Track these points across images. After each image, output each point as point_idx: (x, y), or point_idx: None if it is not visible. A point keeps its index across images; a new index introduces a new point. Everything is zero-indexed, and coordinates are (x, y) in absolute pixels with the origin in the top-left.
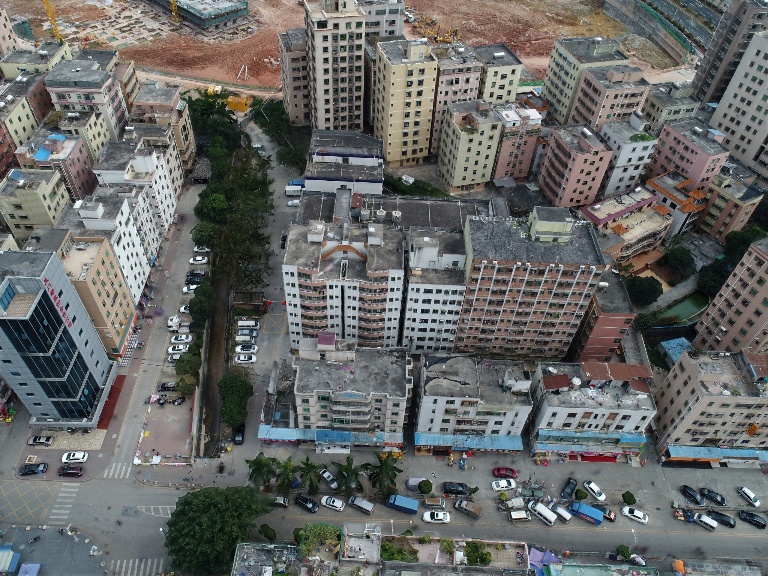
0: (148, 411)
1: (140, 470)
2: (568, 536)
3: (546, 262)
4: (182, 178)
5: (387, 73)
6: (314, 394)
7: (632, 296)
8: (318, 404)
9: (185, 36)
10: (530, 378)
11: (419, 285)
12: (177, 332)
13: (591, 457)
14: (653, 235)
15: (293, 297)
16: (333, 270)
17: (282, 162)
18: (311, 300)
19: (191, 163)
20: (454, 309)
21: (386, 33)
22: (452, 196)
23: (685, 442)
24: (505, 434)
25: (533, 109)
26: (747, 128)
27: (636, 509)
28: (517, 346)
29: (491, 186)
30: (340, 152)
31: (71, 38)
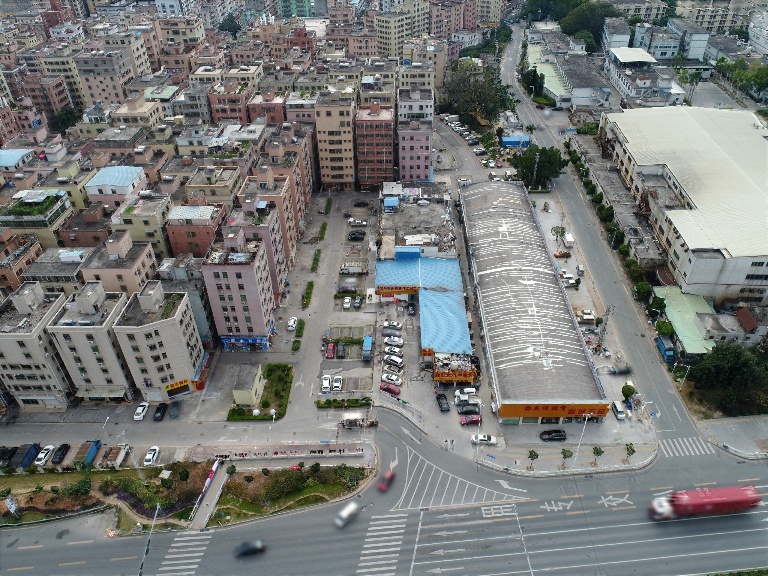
0: None
1: None
2: None
3: None
4: None
5: None
6: None
7: None
8: None
9: None
10: None
11: None
12: None
13: None
14: None
15: None
16: None
17: None
18: None
19: None
20: None
21: None
22: None
23: (240, 8)
24: None
25: None
26: None
27: None
28: None
29: None
30: (118, 0)
31: None
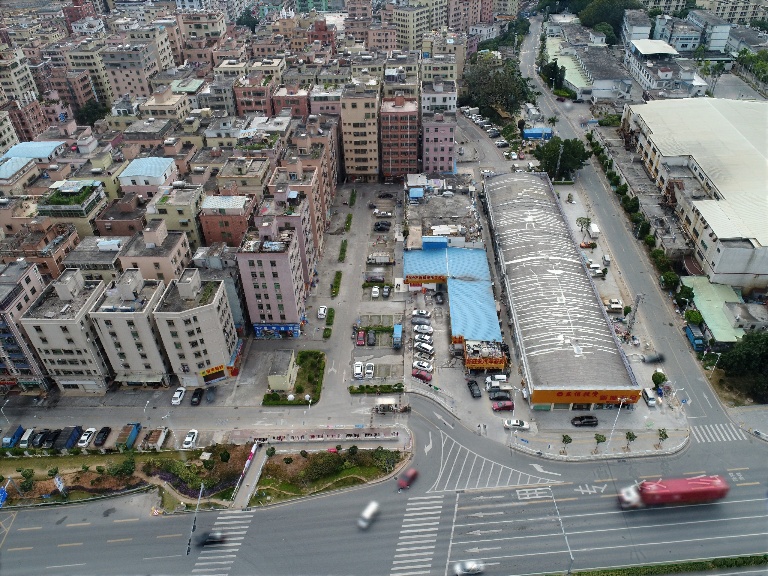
0: None
1: None
2: None
3: None
4: None
5: None
6: (226, 6)
7: None
8: None
9: None
10: None
11: None
12: None
13: None
14: None
15: None
16: None
17: None
18: None
19: None
20: None
21: None
22: None
23: (256, 2)
24: None
25: None
26: None
27: None
28: None
29: None
30: None
31: None
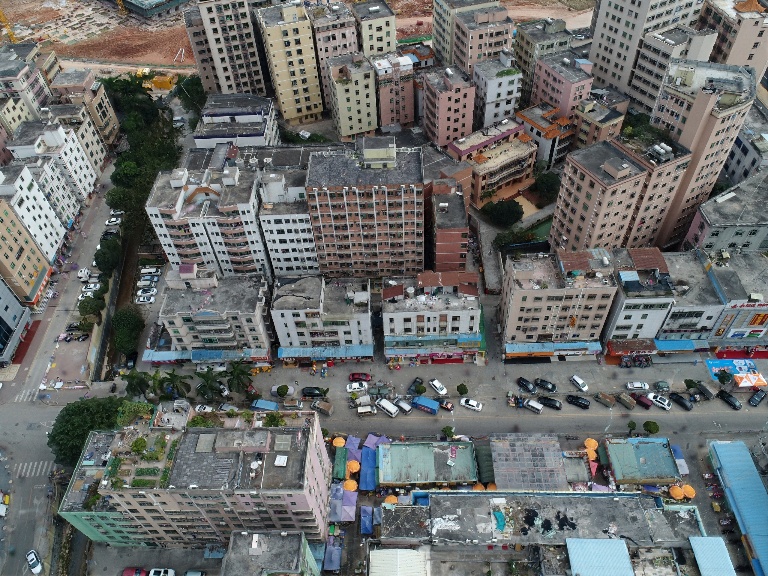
0: (56, 347)
1: (45, 394)
2: (408, 425)
3: None
4: (104, 152)
5: (266, 36)
6: (176, 315)
7: (495, 219)
8: (185, 326)
9: (130, 27)
10: (366, 289)
11: (268, 216)
12: (88, 282)
13: (441, 360)
14: (518, 162)
15: (165, 237)
16: (196, 210)
17: (194, 130)
18: (180, 239)
19: (113, 138)
20: (307, 237)
21: (278, 1)
22: None
23: (522, 340)
24: (358, 343)
25: (406, 56)
26: (618, 55)
27: (474, 400)
28: (377, 269)
29: (381, 133)
30: (226, 112)
31: (26, 40)
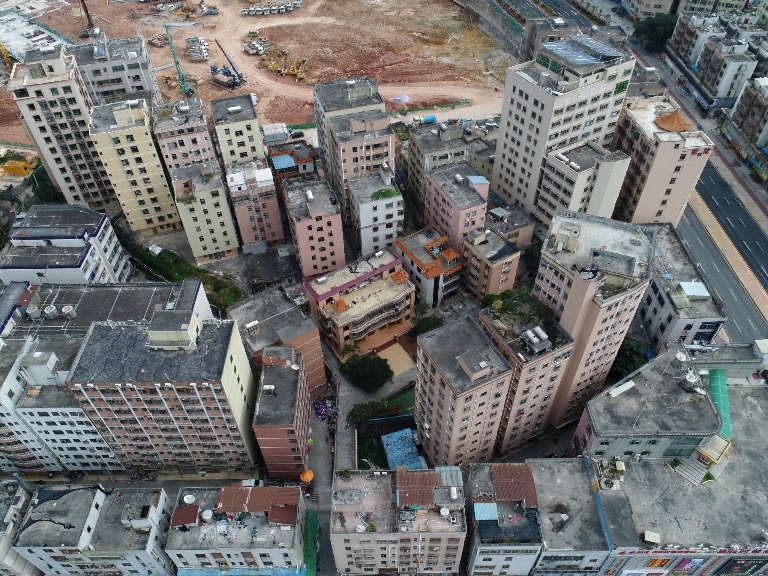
0: None
1: None
2: None
3: (156, 379)
4: None
5: None
6: None
7: (355, 382)
8: None
9: None
10: (146, 516)
11: (28, 409)
12: None
13: None
14: (392, 306)
15: None
16: None
17: None
18: None
19: None
20: (88, 429)
21: (133, 89)
22: (195, 267)
23: (360, 571)
24: (147, 573)
25: (267, 169)
26: (522, 170)
27: None
28: (191, 458)
29: None
30: (40, 234)
31: None
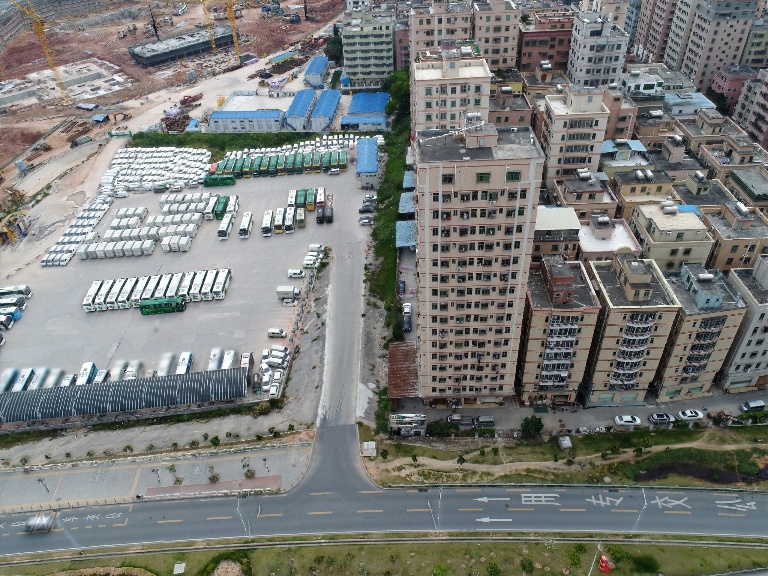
0: None
1: None
2: None
3: None
4: None
5: None
6: None
7: None
8: None
9: None
10: None
11: None
12: None
13: None
14: None
15: None
16: None
17: None
18: None
19: None
20: None
21: None
22: None
23: None
24: None
25: None
26: None
27: None
28: None
29: None
30: None
31: None
